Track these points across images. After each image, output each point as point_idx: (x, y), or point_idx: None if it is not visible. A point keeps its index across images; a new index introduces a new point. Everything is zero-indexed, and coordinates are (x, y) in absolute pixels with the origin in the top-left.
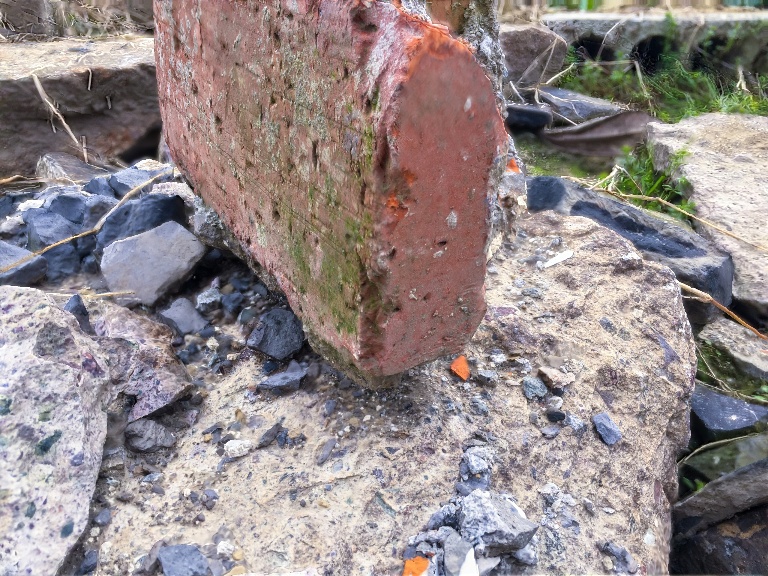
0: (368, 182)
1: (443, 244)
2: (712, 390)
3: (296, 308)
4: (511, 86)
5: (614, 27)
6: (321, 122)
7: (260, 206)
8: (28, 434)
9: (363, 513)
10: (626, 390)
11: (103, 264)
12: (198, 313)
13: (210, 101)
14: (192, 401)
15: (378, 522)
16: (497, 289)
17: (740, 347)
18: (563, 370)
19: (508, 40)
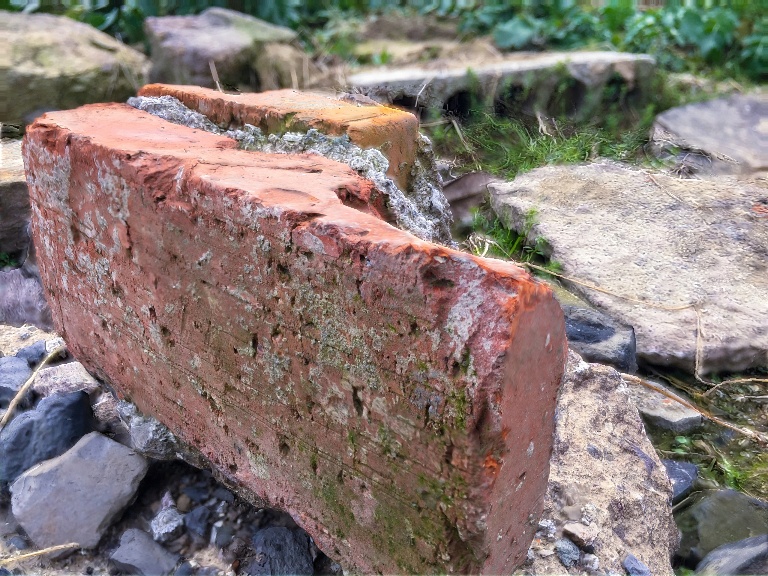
0: (459, 444)
1: (523, 475)
2: None
3: (330, 551)
4: None
5: (424, 88)
6: (371, 370)
7: (254, 435)
8: None
9: None
10: (632, 517)
11: (16, 509)
12: (161, 546)
13: (149, 309)
14: None
15: None
16: None
17: (645, 402)
18: (586, 523)
19: None
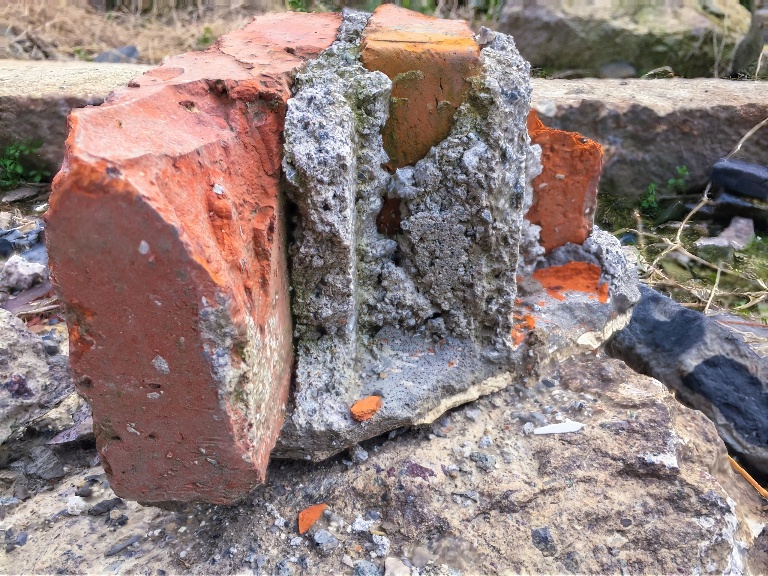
0: None
1: (157, 386)
2: None
3: None
4: None
5: None
6: None
7: None
8: None
9: None
10: None
11: None
12: None
13: None
14: None
15: None
16: (451, 440)
17: None
18: (412, 573)
19: None
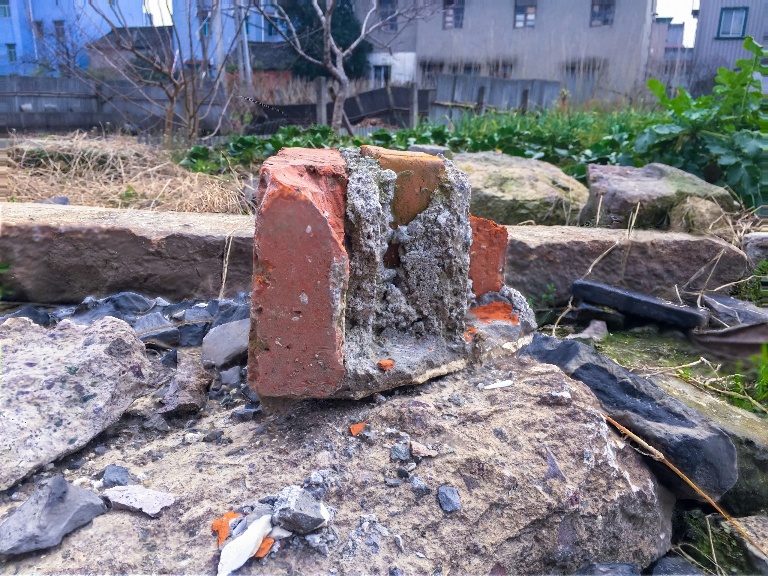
0: None
1: (299, 313)
2: (703, 571)
3: None
4: (675, 289)
5: None
6: None
7: None
8: (80, 389)
9: (227, 483)
10: (491, 483)
11: (205, 338)
12: (239, 375)
13: None
14: (195, 416)
15: (232, 490)
16: (434, 394)
17: (759, 543)
18: (428, 446)
19: (679, 248)
